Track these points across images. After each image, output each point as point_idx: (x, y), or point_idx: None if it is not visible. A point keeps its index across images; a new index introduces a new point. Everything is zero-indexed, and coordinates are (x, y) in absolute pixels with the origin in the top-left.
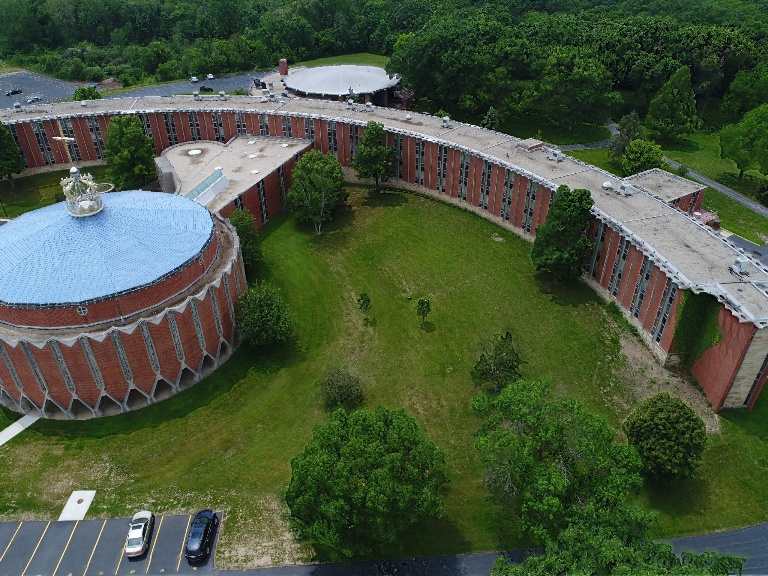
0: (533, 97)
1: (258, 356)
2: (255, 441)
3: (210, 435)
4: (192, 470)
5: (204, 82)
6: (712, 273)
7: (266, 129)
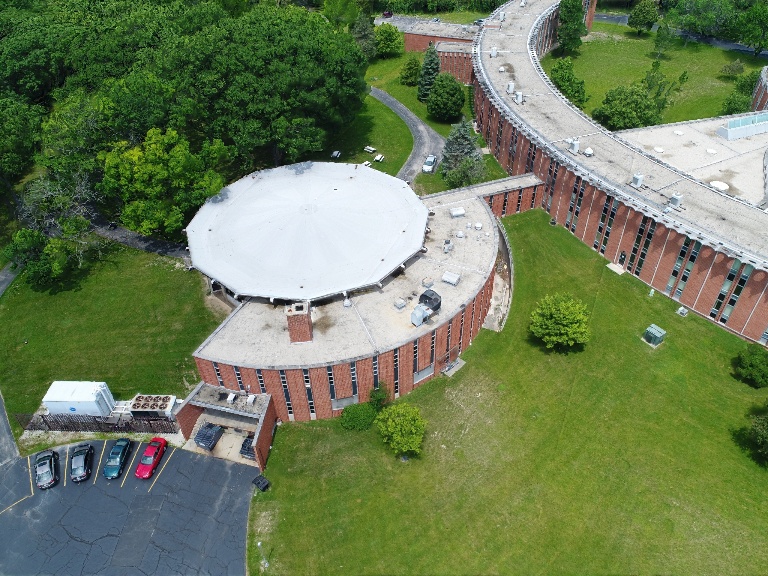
0: None
1: None
2: None
3: None
4: None
5: None
6: None
7: None
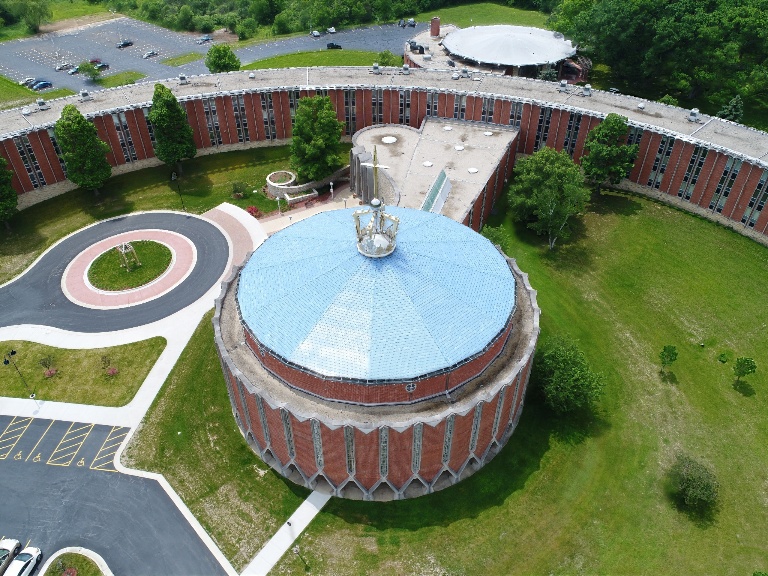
0: (766, 79)
1: (552, 419)
2: (602, 546)
3: (542, 532)
4: None
5: (326, 37)
6: None
7: (461, 112)
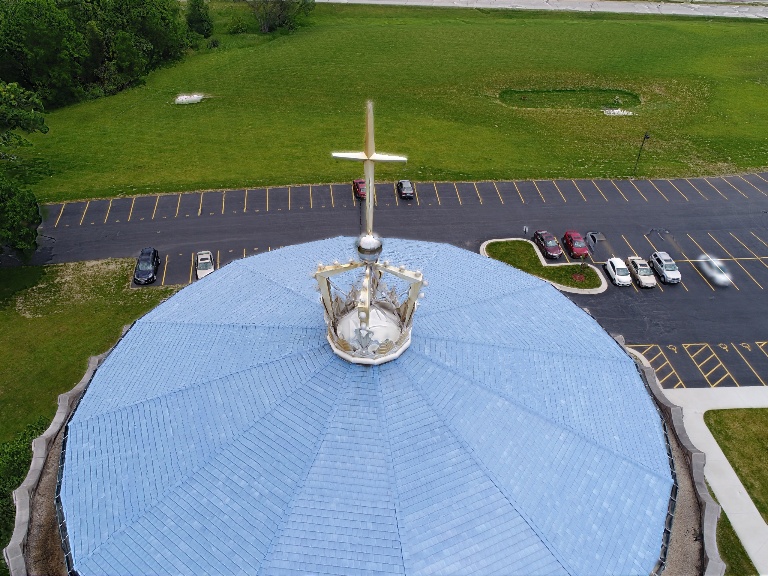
0: None
1: None
2: (94, 351)
3: None
4: None
5: None
6: None
7: None
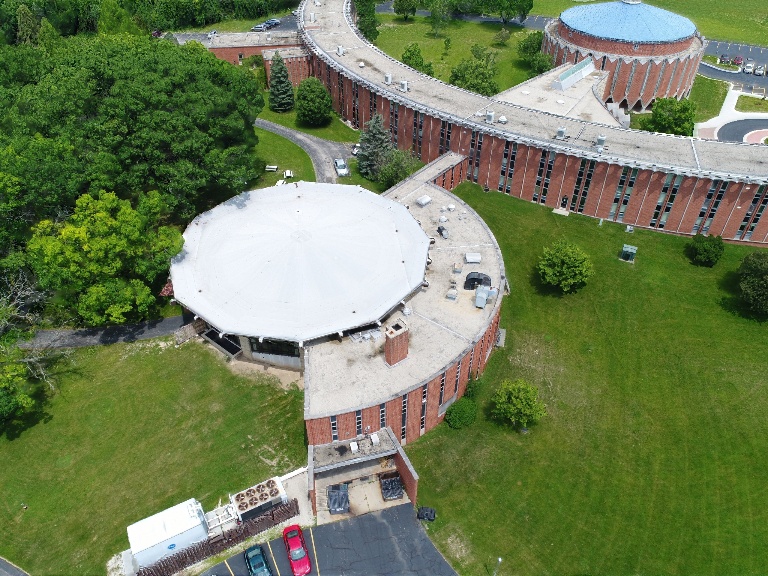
0: None
1: None
2: None
3: None
4: None
5: None
6: None
7: None
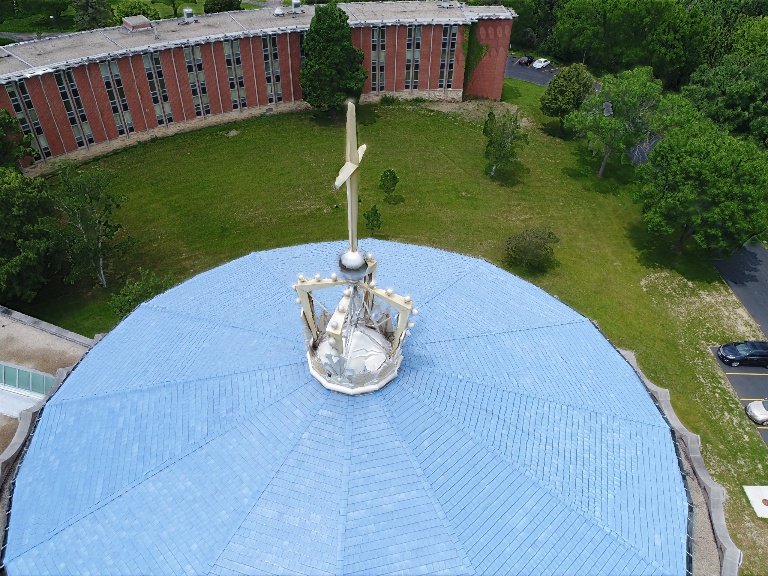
0: None
1: None
2: None
3: None
4: (667, 383)
5: None
6: (449, 12)
7: None
